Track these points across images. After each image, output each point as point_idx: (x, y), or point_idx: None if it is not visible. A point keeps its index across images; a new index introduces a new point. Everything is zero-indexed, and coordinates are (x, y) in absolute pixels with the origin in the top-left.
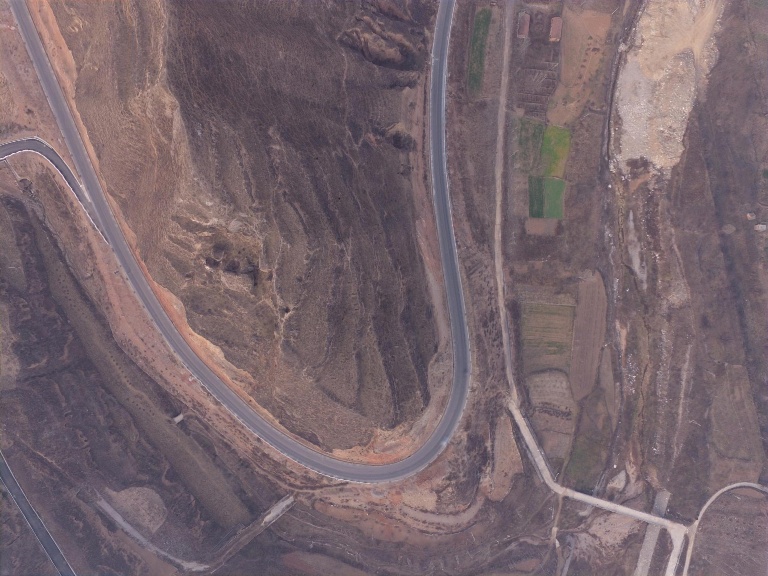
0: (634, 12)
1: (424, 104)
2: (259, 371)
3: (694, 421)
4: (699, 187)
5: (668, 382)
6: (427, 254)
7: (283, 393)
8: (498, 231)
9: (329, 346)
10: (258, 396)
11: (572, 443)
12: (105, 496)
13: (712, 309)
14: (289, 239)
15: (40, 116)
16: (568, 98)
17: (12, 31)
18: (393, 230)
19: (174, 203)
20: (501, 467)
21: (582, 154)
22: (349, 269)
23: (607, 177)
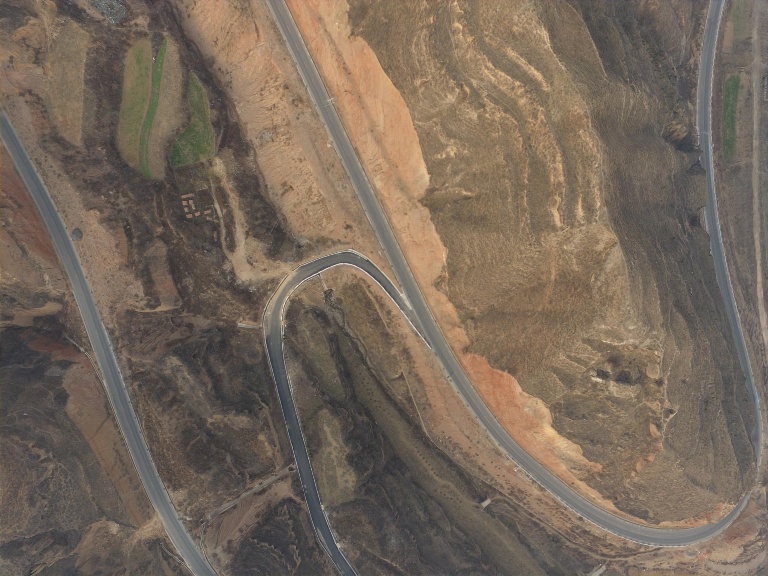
0: None
1: None
2: (614, 463)
3: None
4: None
5: None
6: None
7: (640, 481)
8: (760, 289)
9: None
10: (598, 482)
11: None
12: None
13: None
14: (679, 346)
15: (360, 230)
16: None
17: (328, 149)
18: None
19: (591, 328)
20: None
21: None
22: None
23: None
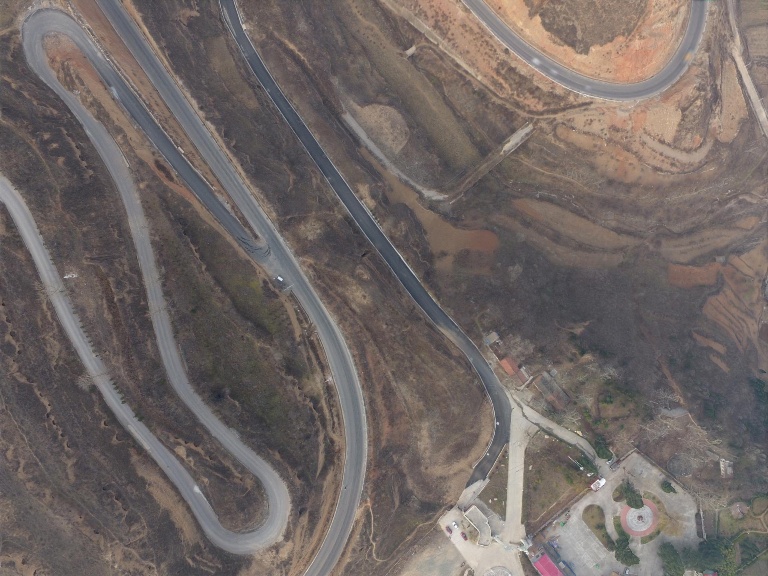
0: None
1: None
2: None
3: None
4: None
5: None
6: None
7: None
8: None
9: None
10: None
11: None
12: (350, 109)
13: None
14: None
15: None
16: None
17: None
18: None
19: None
20: (728, 110)
21: None
22: None
23: None
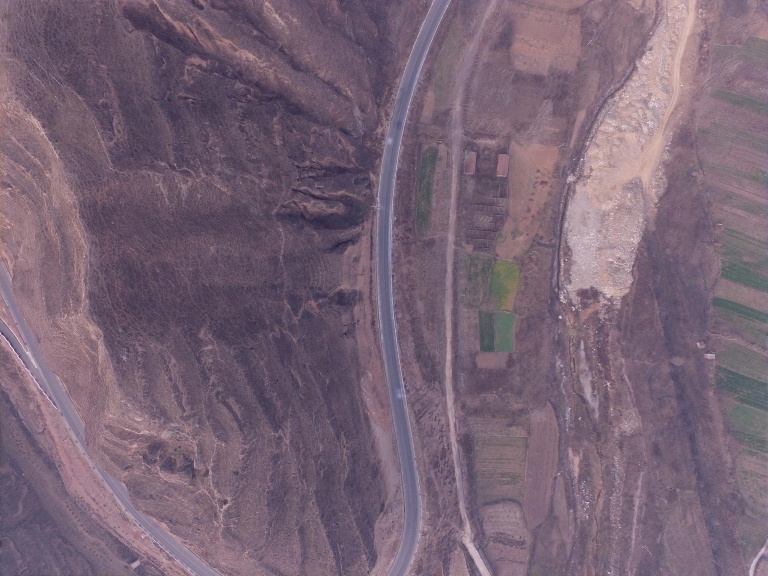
0: (582, 142)
1: (371, 249)
2: (205, 544)
3: (646, 548)
4: (648, 318)
5: (621, 508)
6: (373, 408)
7: (229, 565)
8: (449, 368)
9: (270, 527)
10: (207, 560)
11: (527, 571)
12: None
13: (663, 437)
14: (224, 437)
15: None
16: (517, 232)
17: None
18: (335, 397)
19: (105, 416)
20: None
21: (531, 288)
22: (288, 451)
23: (557, 308)
